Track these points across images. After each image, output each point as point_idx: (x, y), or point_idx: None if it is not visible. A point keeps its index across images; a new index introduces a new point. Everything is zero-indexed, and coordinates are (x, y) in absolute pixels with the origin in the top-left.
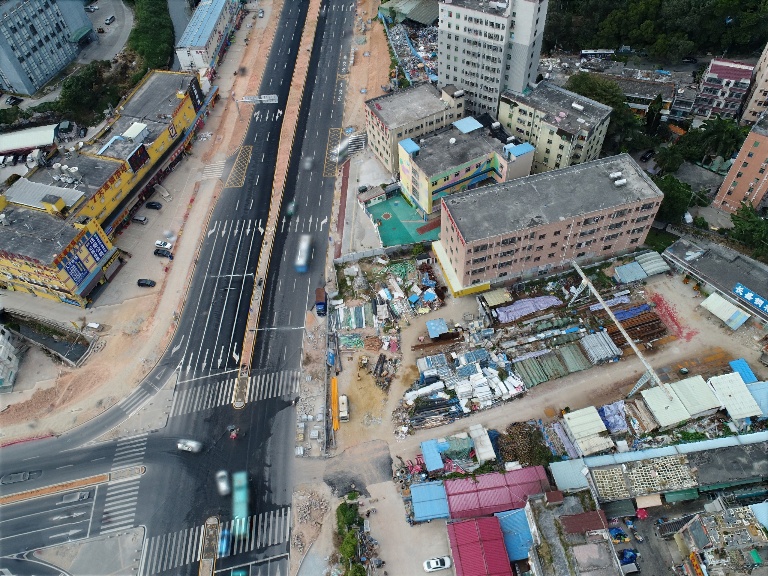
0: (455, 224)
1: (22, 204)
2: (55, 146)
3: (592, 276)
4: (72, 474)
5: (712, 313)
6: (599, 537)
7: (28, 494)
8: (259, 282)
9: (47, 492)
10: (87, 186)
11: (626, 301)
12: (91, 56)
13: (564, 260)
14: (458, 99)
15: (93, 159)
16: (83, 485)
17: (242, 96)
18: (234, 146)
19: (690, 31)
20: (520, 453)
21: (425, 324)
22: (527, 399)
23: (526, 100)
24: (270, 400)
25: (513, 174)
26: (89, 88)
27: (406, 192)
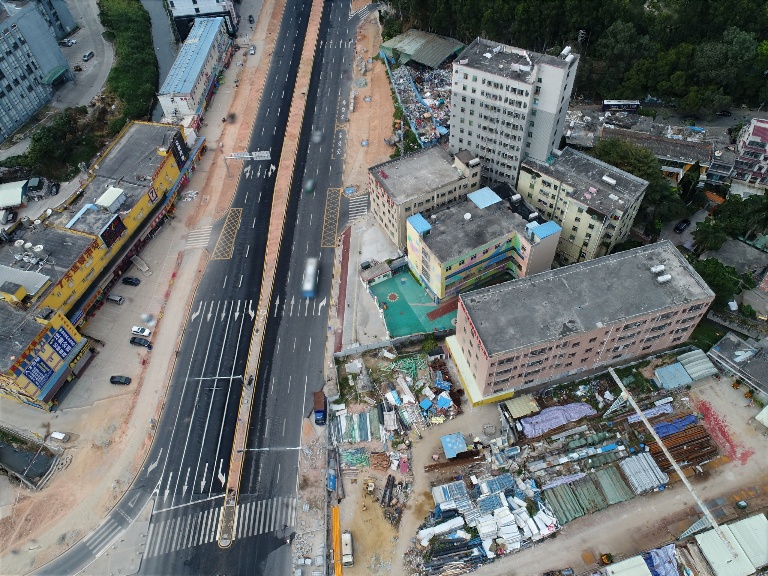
0: (476, 331)
1: None
2: (23, 206)
3: (628, 378)
4: None
5: None
6: None
7: None
8: (249, 381)
9: None
10: (53, 267)
11: (669, 411)
12: (66, 98)
13: (598, 363)
14: (473, 168)
15: (61, 233)
16: None
17: (231, 148)
18: (222, 208)
19: (725, 83)
20: None
21: (439, 438)
22: (561, 539)
23: (550, 170)
24: (261, 537)
25: (536, 256)
26: (62, 139)
27: (414, 269)
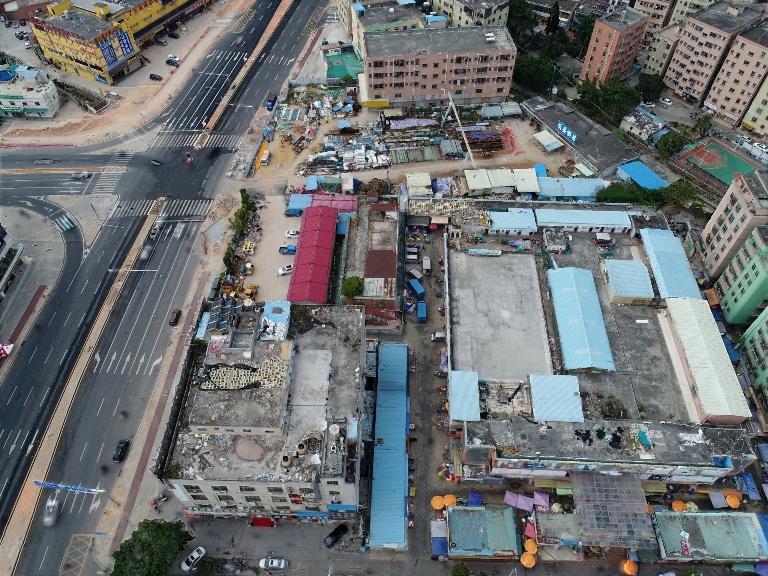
0: (365, 47)
1: (81, 8)
2: None
3: (466, 112)
4: (80, 165)
5: (538, 141)
6: (392, 219)
7: (50, 170)
8: (233, 87)
9: (62, 171)
10: (127, 5)
11: (484, 129)
12: None
13: (445, 94)
14: None
15: None
16: (86, 171)
17: None
18: (243, 8)
19: None
20: (370, 191)
21: None
22: (390, 170)
23: None
24: (219, 148)
25: None
26: None
27: (355, 48)
